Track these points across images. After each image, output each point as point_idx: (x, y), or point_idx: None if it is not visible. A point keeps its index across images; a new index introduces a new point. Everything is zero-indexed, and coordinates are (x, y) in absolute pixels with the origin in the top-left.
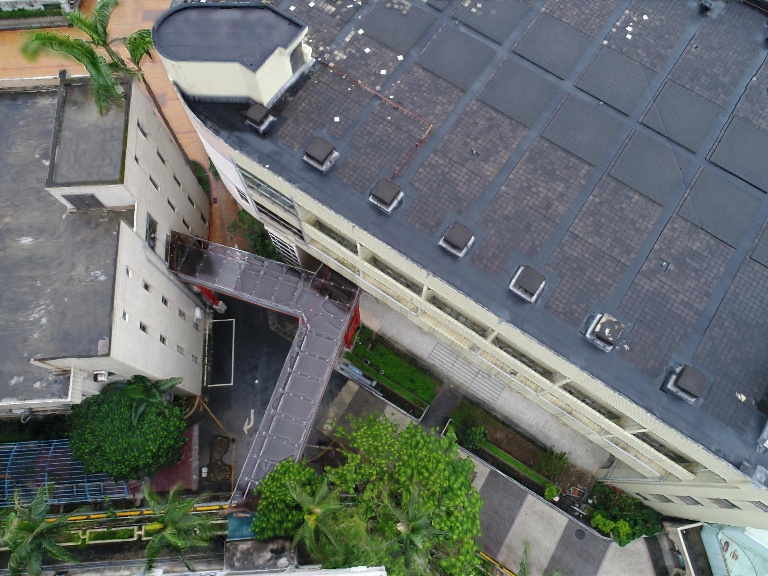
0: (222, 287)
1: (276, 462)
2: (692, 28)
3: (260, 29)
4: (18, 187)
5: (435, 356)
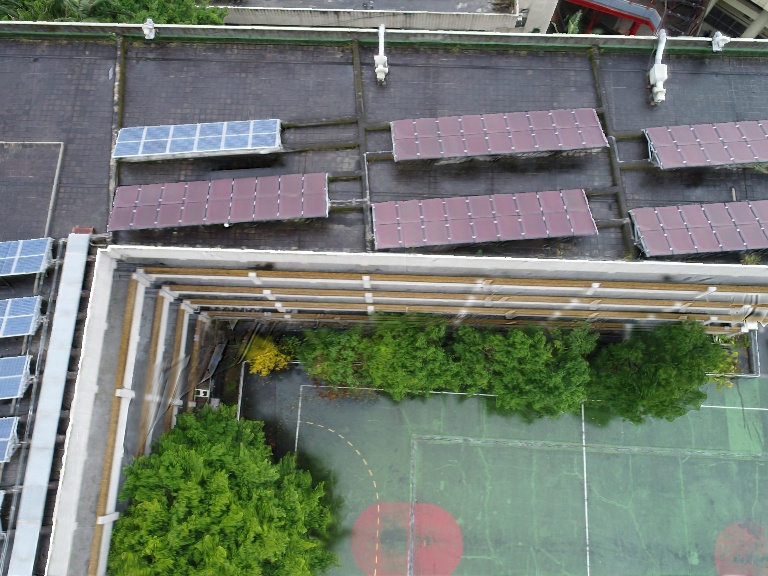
0: None
1: None
2: None
3: None
4: None
5: None
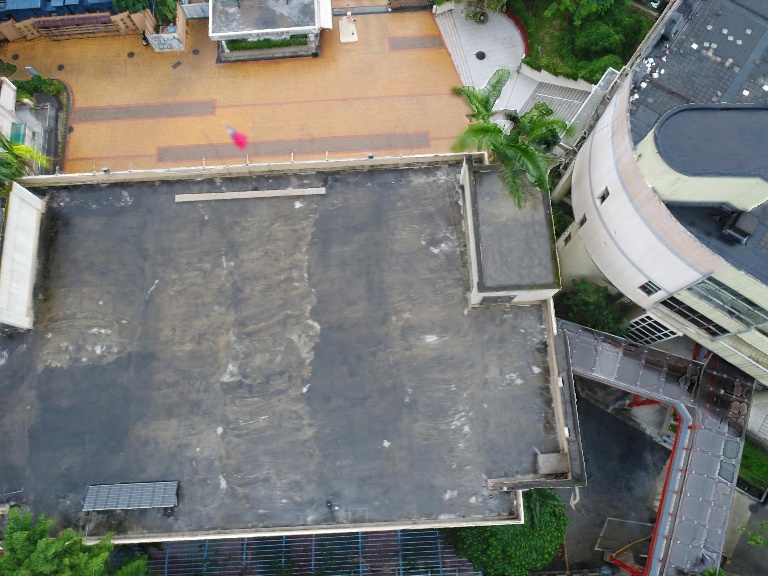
0: (602, 377)
1: (696, 573)
2: None
3: None
4: (411, 278)
5: (766, 430)
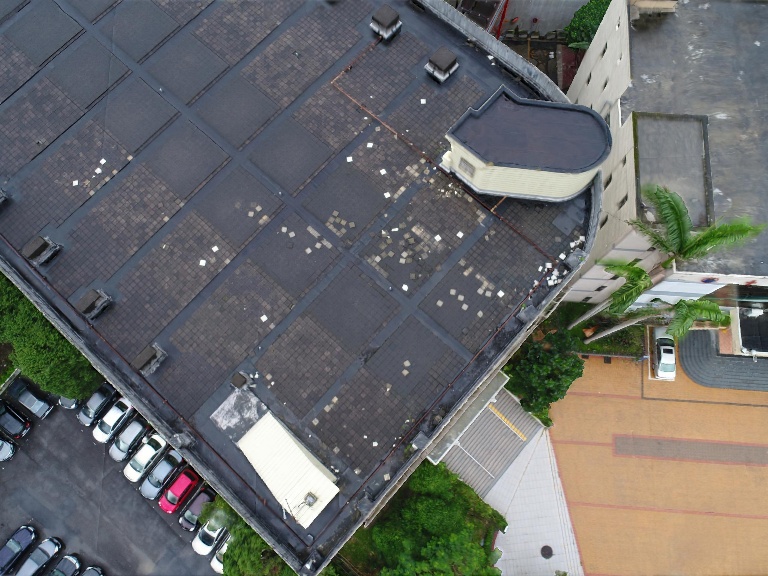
0: None
1: None
2: (32, 167)
3: (497, 138)
4: (741, 169)
5: None
